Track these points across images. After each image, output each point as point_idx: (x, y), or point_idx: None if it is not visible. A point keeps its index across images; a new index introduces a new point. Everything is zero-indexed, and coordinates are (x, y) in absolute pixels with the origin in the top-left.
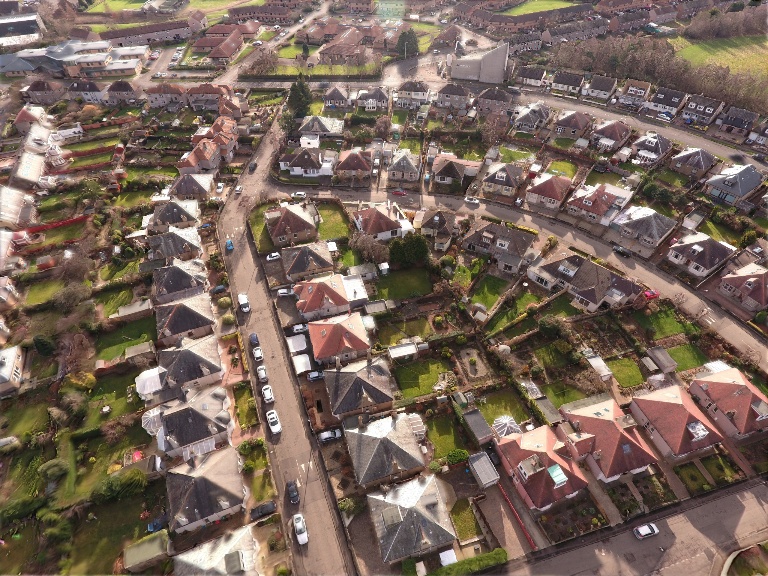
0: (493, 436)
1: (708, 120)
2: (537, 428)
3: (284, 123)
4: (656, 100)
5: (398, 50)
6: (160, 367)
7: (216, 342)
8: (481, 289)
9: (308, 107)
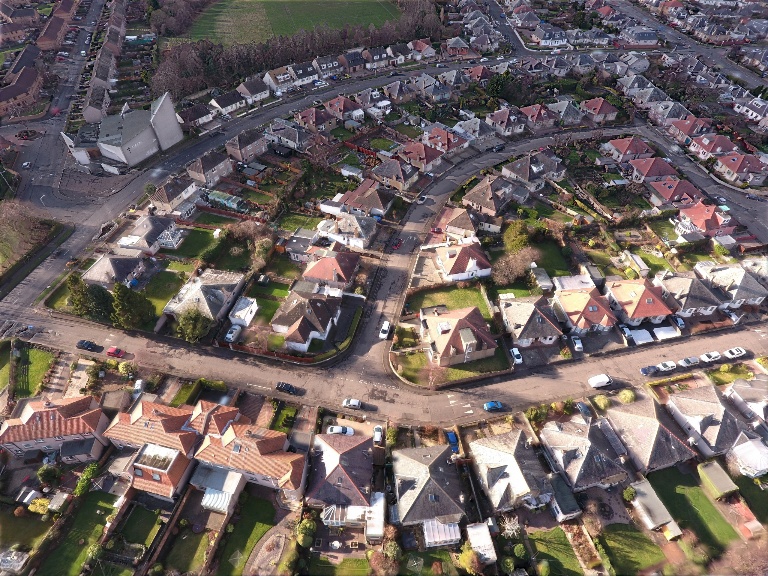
0: None
1: None
2: (686, 213)
3: (197, 328)
4: (300, 76)
5: None
6: (736, 444)
7: (681, 393)
8: (548, 217)
9: None
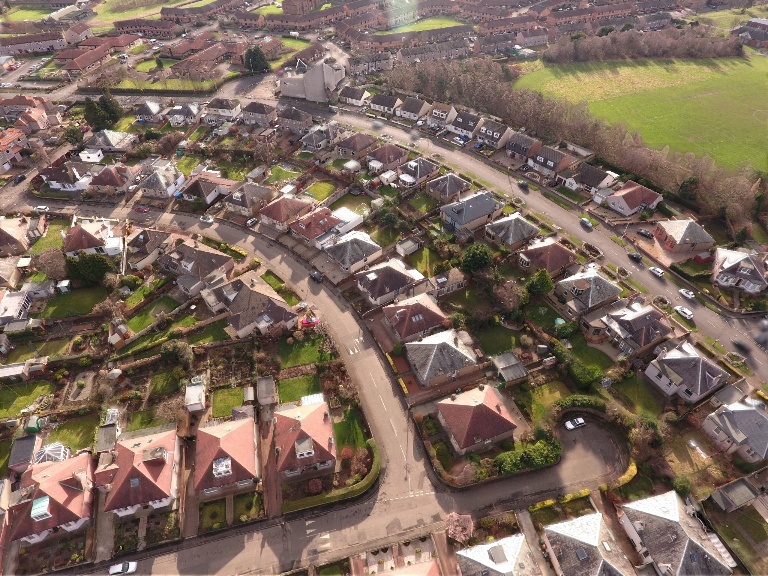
0: (29, 463)
1: (496, 145)
2: (74, 457)
3: (68, 137)
4: (456, 123)
5: (247, 66)
6: None
7: None
8: (147, 310)
9: (108, 121)
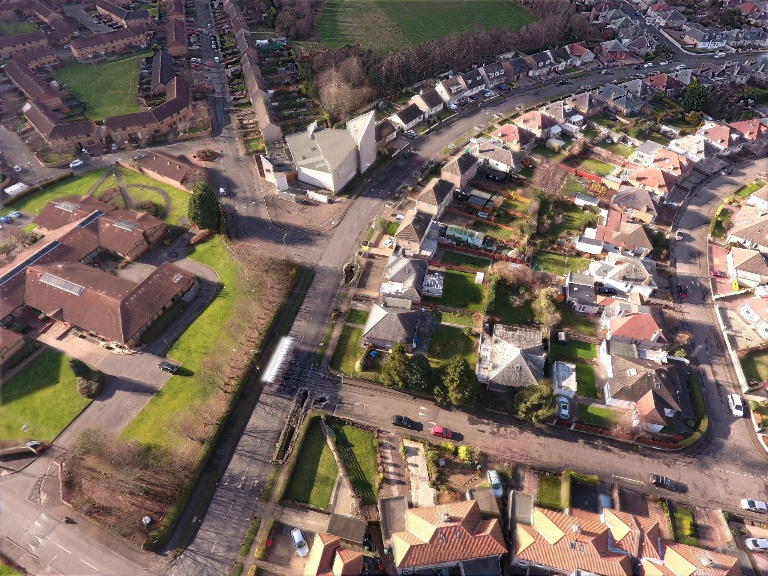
0: None
1: None
2: None
3: None
4: (470, 86)
5: (206, 226)
6: None
7: None
8: None
9: None
